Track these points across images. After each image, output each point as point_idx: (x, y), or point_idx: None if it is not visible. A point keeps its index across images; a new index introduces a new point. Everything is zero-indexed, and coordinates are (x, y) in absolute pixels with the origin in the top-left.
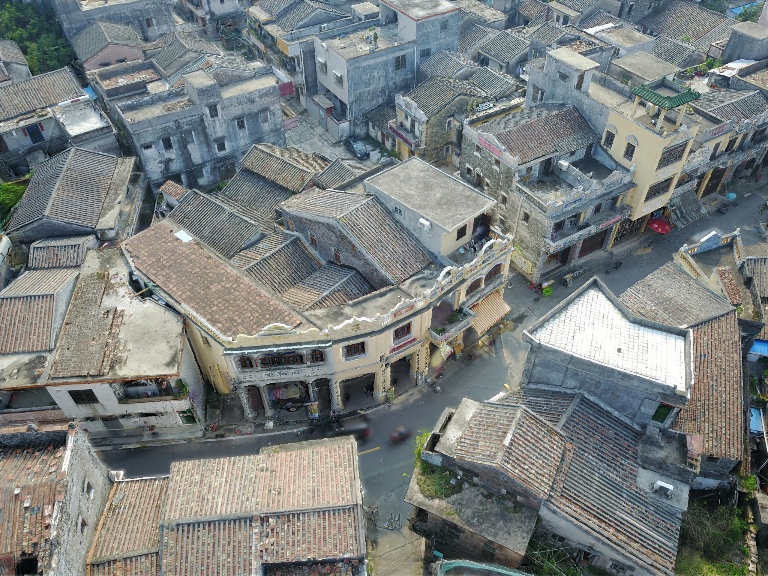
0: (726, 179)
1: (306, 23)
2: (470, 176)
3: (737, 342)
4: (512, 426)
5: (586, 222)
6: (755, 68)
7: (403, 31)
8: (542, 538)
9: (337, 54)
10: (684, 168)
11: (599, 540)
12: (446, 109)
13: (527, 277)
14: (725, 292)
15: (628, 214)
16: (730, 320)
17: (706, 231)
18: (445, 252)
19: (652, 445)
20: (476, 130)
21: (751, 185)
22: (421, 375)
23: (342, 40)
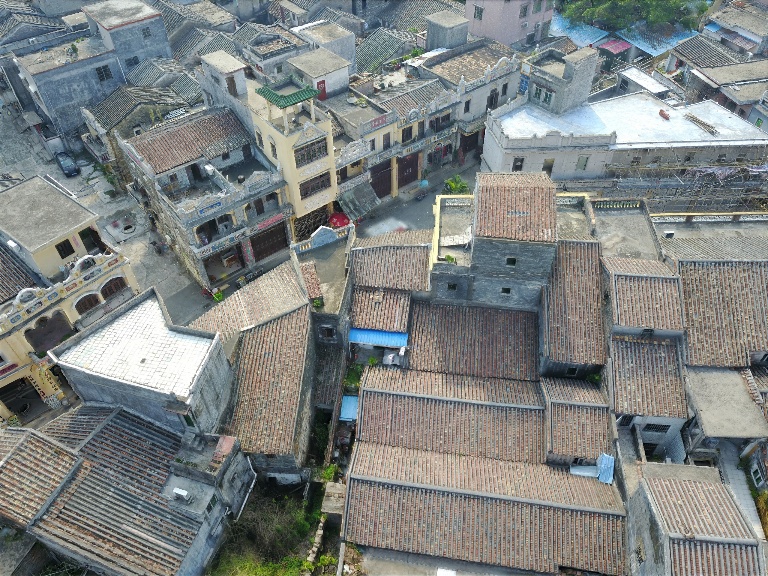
0: (422, 167)
1: (12, 38)
2: (139, 187)
3: (303, 336)
4: (9, 452)
5: (240, 224)
6: (447, 56)
7: (105, 41)
8: (67, 560)
9: (26, 70)
10: (339, 162)
11: (87, 558)
12: (128, 119)
13: (200, 284)
14: (304, 287)
15: (291, 212)
16: (301, 315)
17: (397, 220)
18: (49, 272)
19: (192, 451)
20: (127, 141)
21: (454, 170)
22: (52, 398)
23: (43, 54)
